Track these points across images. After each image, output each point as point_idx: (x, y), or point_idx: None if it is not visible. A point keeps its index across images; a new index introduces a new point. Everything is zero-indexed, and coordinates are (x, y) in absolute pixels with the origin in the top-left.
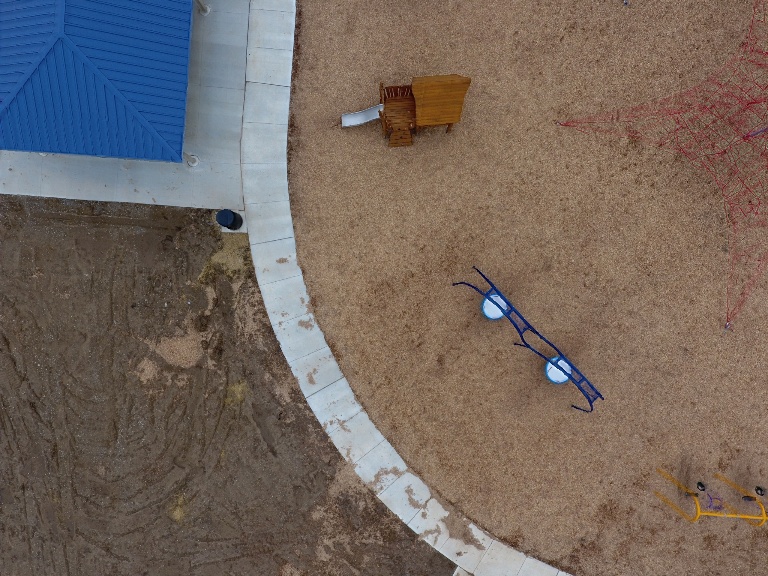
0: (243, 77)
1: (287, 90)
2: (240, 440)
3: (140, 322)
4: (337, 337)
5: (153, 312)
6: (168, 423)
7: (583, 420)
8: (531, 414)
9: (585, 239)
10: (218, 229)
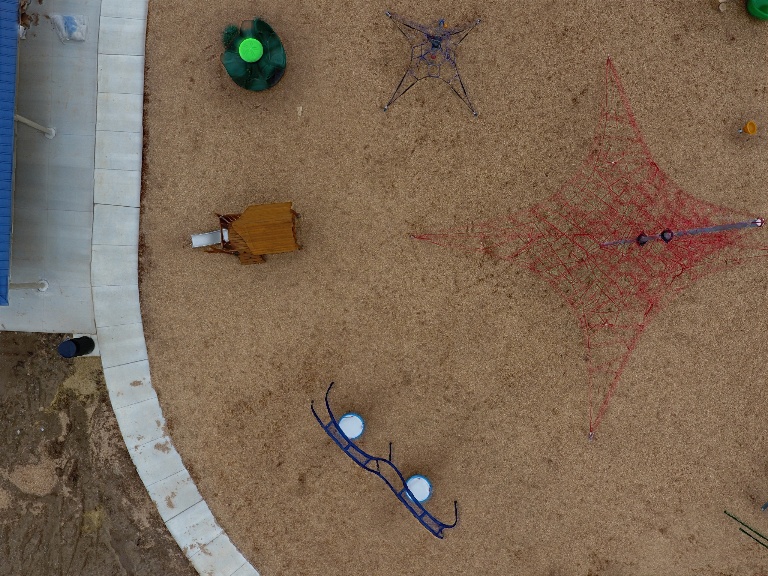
0: (91, 199)
1: (136, 211)
2: (98, 568)
3: None
4: (195, 459)
5: (6, 440)
6: (23, 553)
7: (448, 535)
8: (395, 531)
9: (444, 352)
10: None
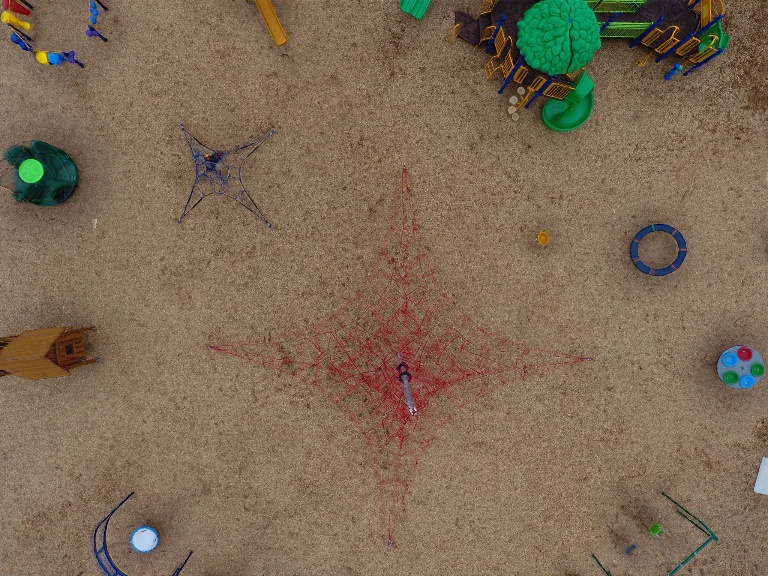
0: None
1: None
2: None
3: None
4: None
5: None
6: None
7: None
8: None
9: (243, 461)
10: None
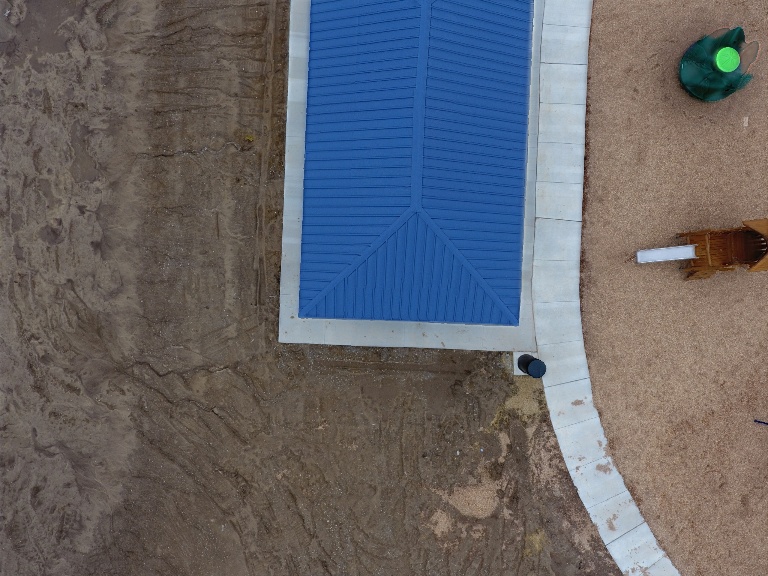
0: (533, 213)
1: (578, 225)
2: None
3: (432, 472)
4: (637, 480)
5: (445, 461)
6: None
7: None
8: None
9: None
10: (510, 372)
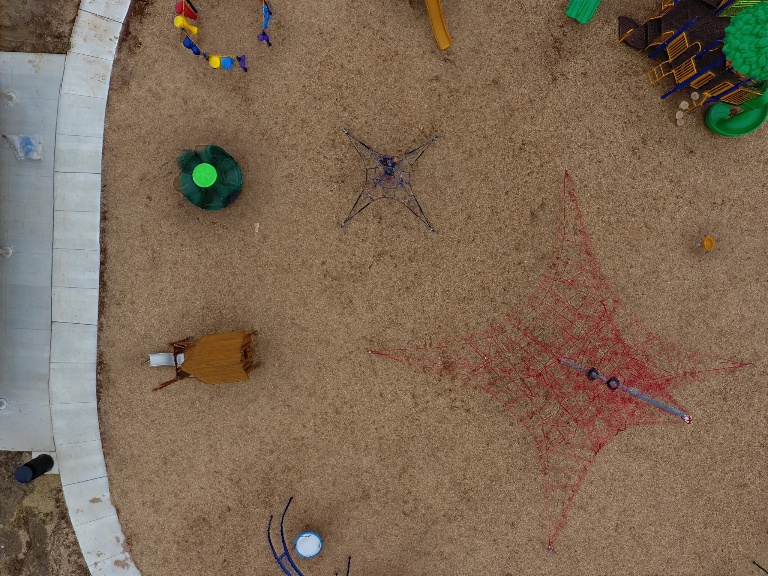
0: (49, 317)
1: (94, 328)
2: None
3: None
4: (154, 575)
5: None
6: None
7: None
8: None
9: (403, 466)
10: None
